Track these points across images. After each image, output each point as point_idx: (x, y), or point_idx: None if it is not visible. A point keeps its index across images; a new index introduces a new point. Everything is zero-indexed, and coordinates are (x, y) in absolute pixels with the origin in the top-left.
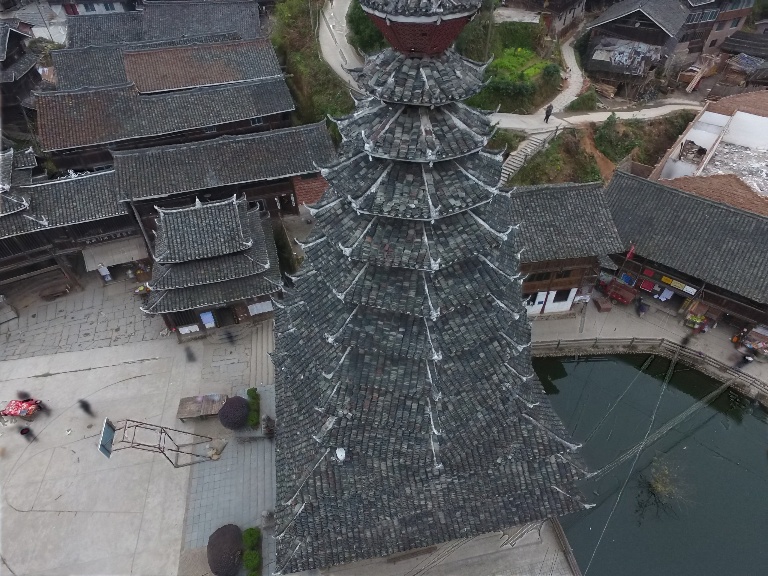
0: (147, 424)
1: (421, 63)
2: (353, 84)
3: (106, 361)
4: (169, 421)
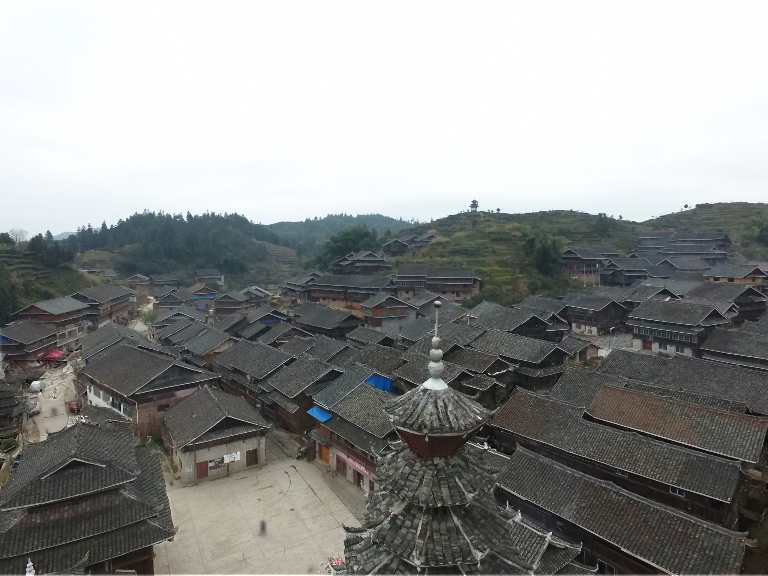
0: None
1: None
2: None
3: None
4: None
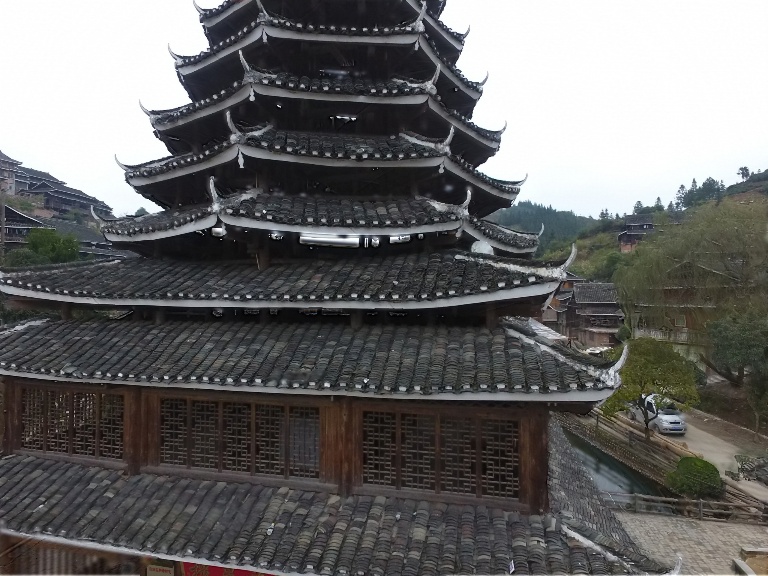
0: None
1: None
2: None
3: None
4: None
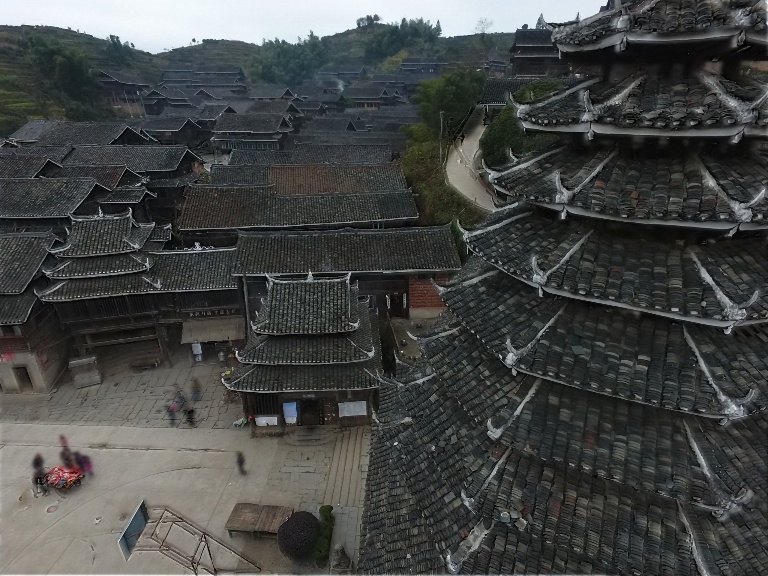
0: (187, 523)
1: None
2: (479, 202)
3: (168, 443)
4: (214, 532)
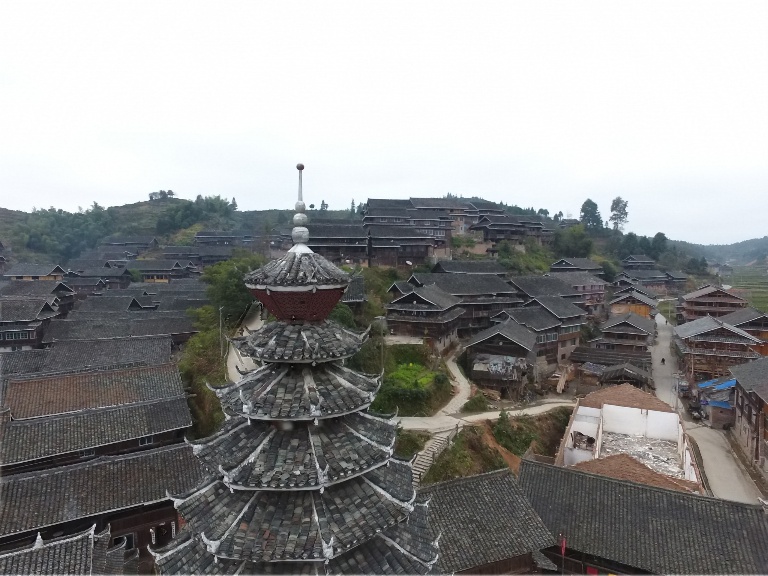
0: None
1: (302, 328)
2: None
3: None
4: None
